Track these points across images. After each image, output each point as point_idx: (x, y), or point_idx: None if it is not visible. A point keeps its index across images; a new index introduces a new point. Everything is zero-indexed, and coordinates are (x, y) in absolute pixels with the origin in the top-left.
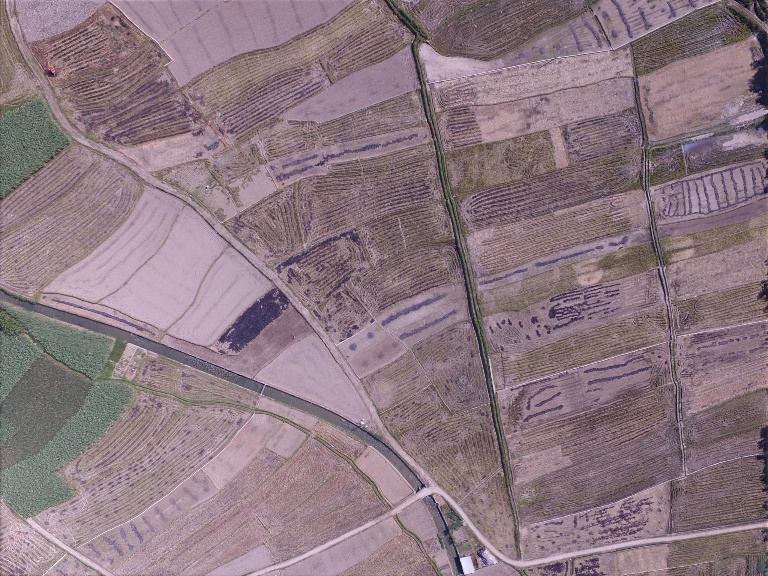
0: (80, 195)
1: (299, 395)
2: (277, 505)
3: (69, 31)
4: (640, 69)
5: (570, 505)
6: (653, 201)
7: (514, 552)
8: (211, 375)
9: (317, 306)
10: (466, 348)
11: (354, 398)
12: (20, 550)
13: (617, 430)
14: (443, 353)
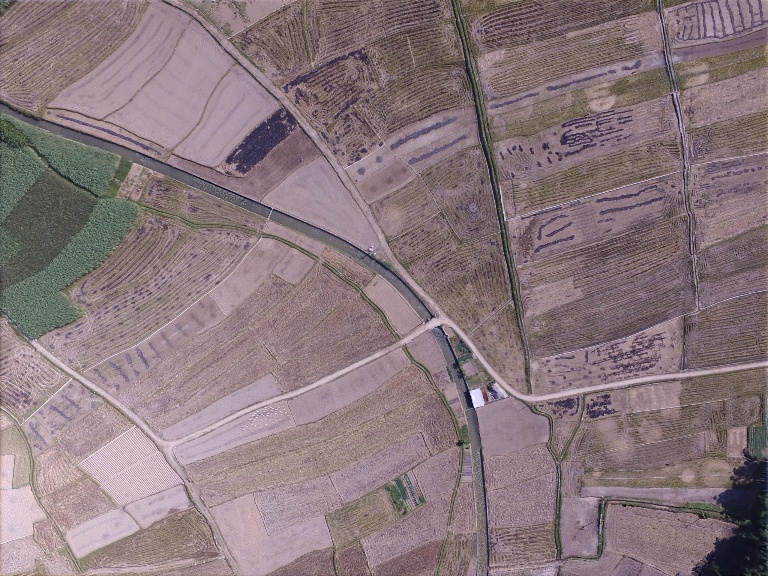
0: (85, 7)
1: (307, 220)
2: (284, 333)
3: None
4: None
5: (581, 339)
6: (667, 23)
7: (524, 387)
8: (218, 198)
9: (325, 128)
10: (476, 174)
11: (362, 224)
12: (25, 374)
13: (629, 262)
14: (453, 179)
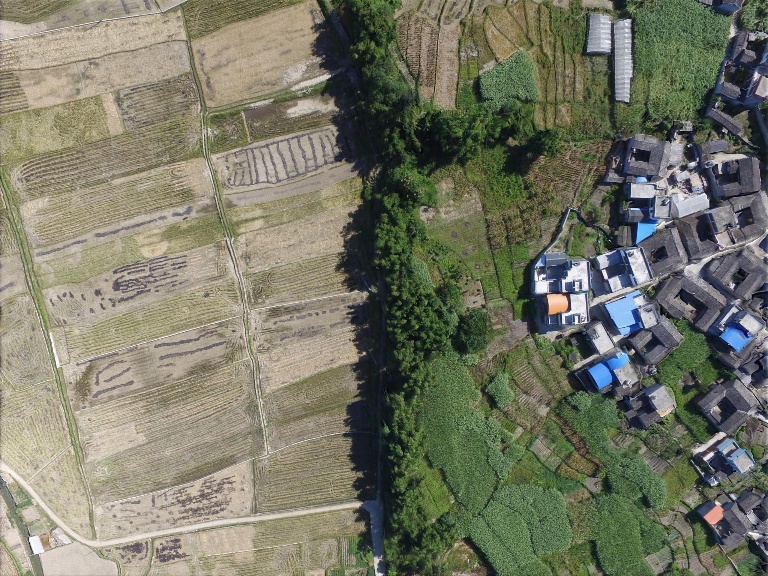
0: None
1: None
2: None
3: None
4: (193, 32)
5: (147, 484)
6: (216, 170)
7: (89, 532)
8: None
9: None
10: (26, 321)
11: None
12: None
13: (193, 407)
14: (2, 326)
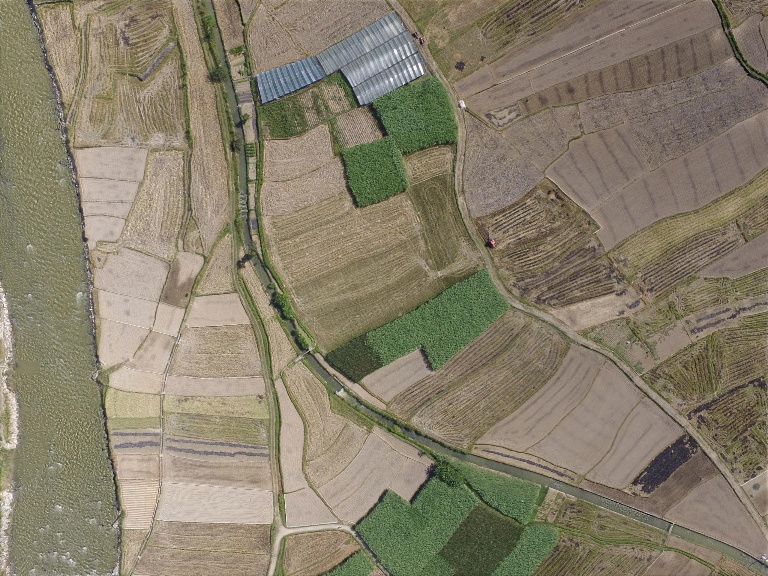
0: (512, 354)
1: (704, 532)
2: None
3: (509, 206)
4: None
5: None
6: None
7: None
8: (623, 515)
9: (724, 449)
10: None
11: (756, 534)
12: None
13: None
14: None
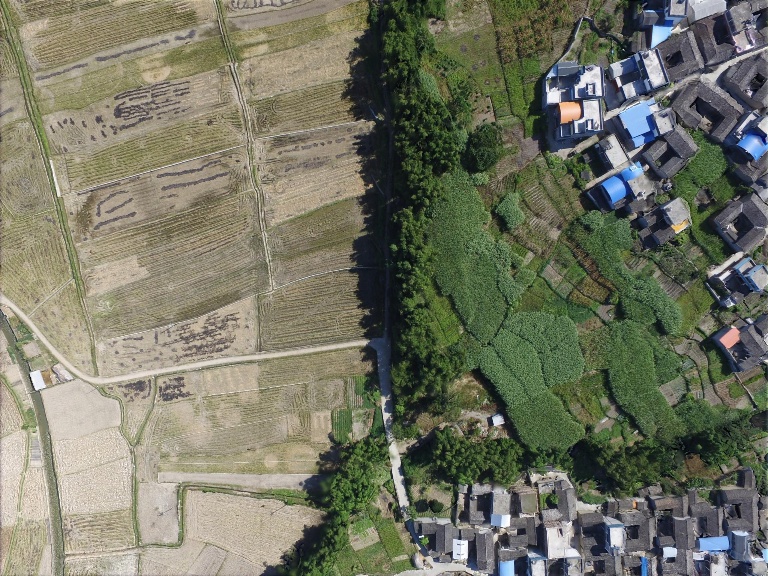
0: None
1: None
2: None
3: None
4: None
5: (150, 320)
6: None
7: (91, 369)
8: None
9: None
10: (26, 149)
11: None
12: None
13: (196, 240)
14: (1, 154)
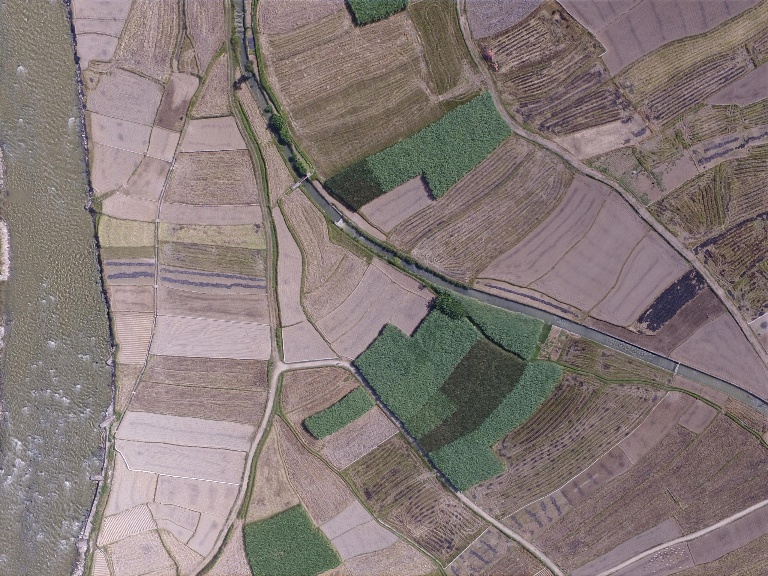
0: (515, 184)
1: (711, 373)
2: (687, 479)
3: (513, 27)
4: None
5: None
6: None
7: None
8: (628, 354)
9: (732, 286)
10: None
11: (763, 375)
12: (449, 522)
13: None
14: None
